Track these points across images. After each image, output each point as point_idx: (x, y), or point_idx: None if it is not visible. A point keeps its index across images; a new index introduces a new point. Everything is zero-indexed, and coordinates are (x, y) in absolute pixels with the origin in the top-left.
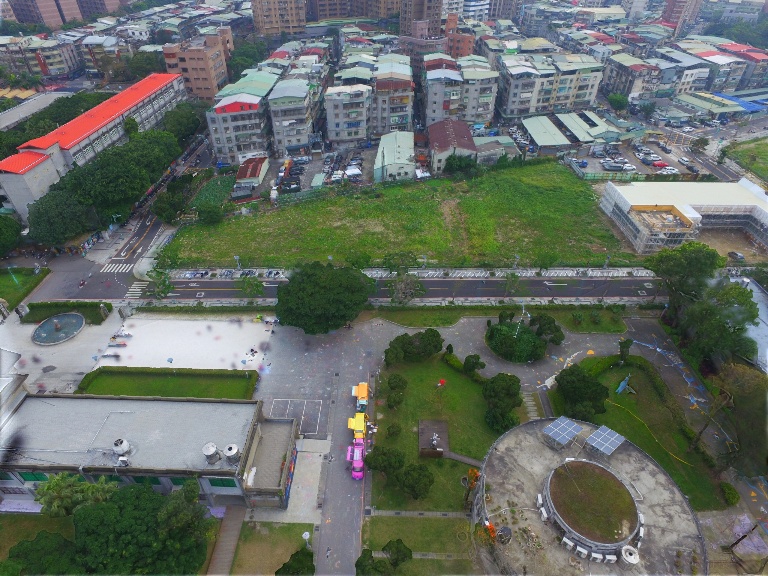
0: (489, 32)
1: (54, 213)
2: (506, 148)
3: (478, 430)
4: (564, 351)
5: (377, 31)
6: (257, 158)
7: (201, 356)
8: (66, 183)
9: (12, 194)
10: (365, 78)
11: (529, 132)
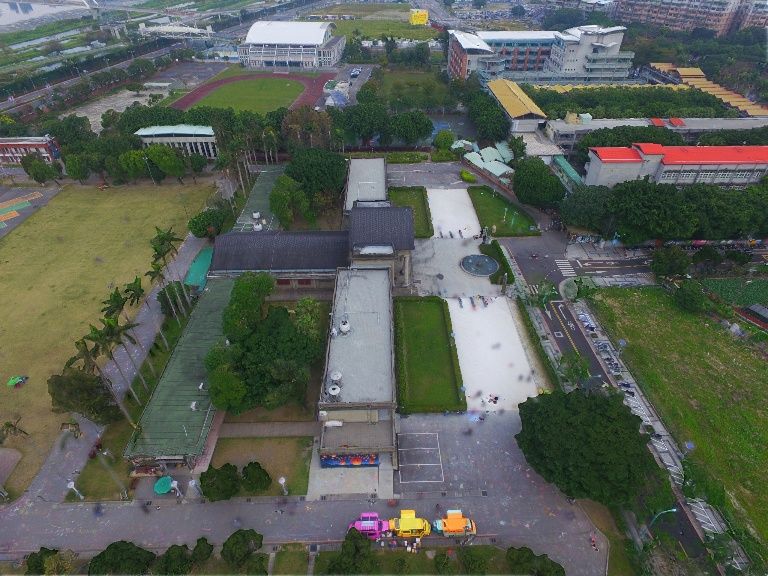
0: None
1: (581, 200)
2: None
3: None
4: None
5: None
6: None
7: (478, 360)
8: (618, 186)
9: (590, 173)
10: None
11: None
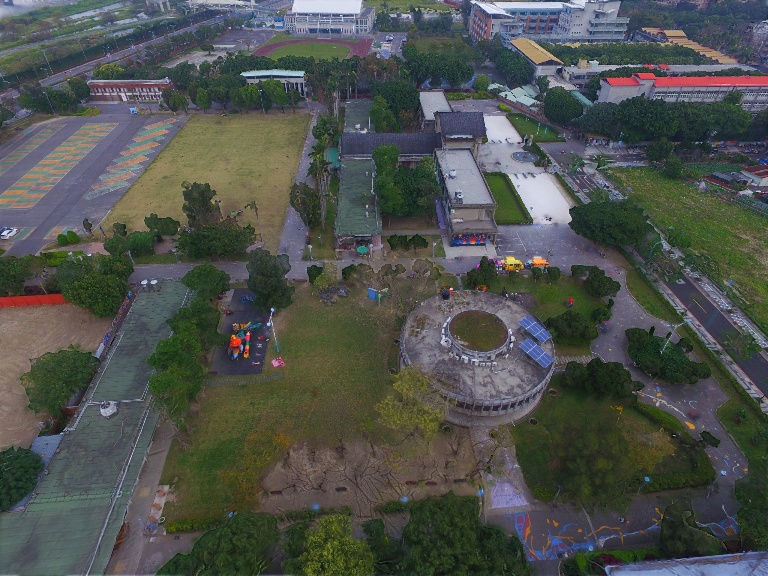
0: None
1: (596, 112)
2: None
3: None
4: (674, 399)
5: None
6: None
7: (534, 202)
8: None
9: (601, 97)
10: None
11: None
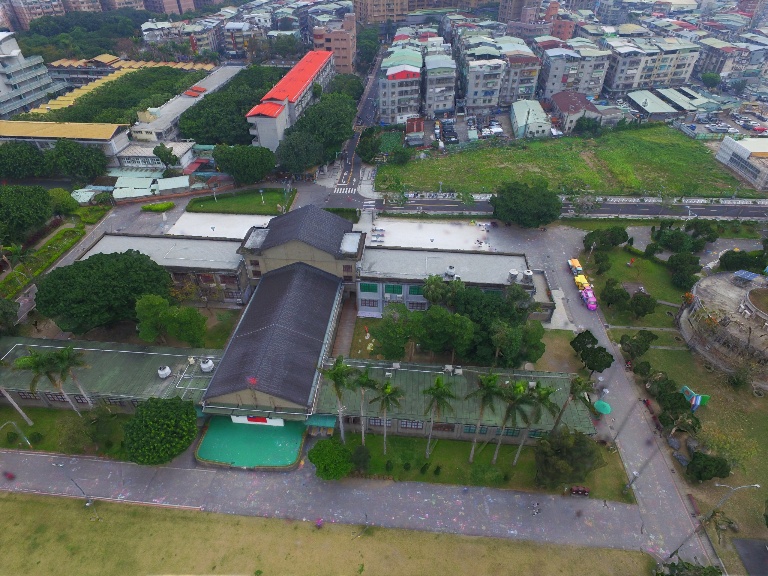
0: (581, 19)
1: (303, 146)
2: (624, 113)
3: (667, 288)
4: (716, 248)
5: (482, 18)
6: (415, 118)
7: (442, 243)
8: None
9: (262, 134)
10: (495, 55)
11: (637, 102)
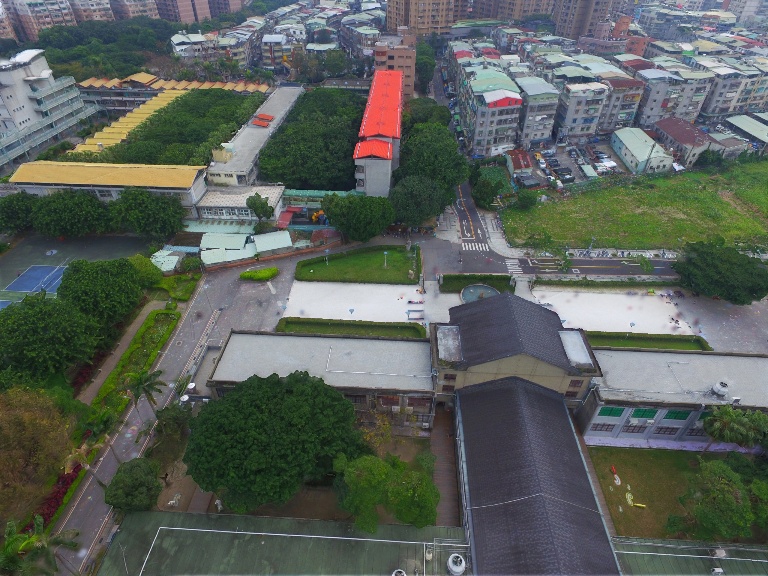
0: (644, 34)
1: (426, 195)
2: None
3: None
4: None
5: (543, 32)
6: (515, 150)
7: None
8: None
9: (370, 178)
10: (588, 77)
11: (744, 130)
